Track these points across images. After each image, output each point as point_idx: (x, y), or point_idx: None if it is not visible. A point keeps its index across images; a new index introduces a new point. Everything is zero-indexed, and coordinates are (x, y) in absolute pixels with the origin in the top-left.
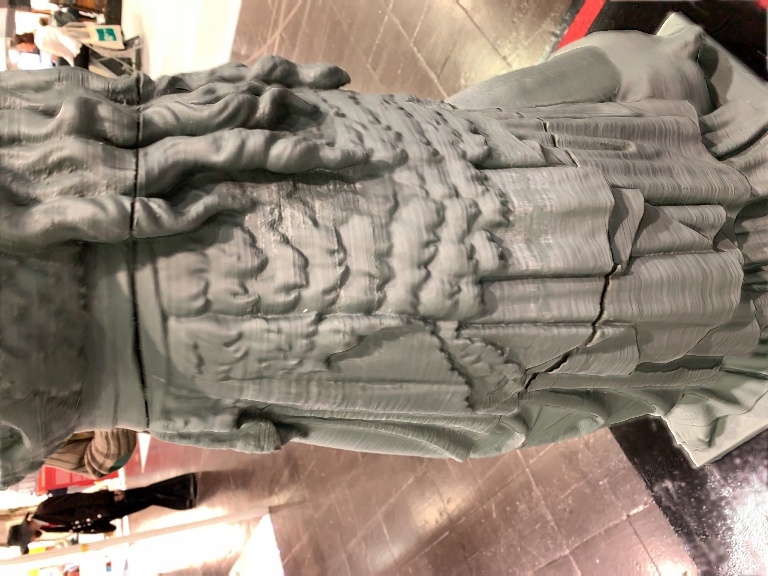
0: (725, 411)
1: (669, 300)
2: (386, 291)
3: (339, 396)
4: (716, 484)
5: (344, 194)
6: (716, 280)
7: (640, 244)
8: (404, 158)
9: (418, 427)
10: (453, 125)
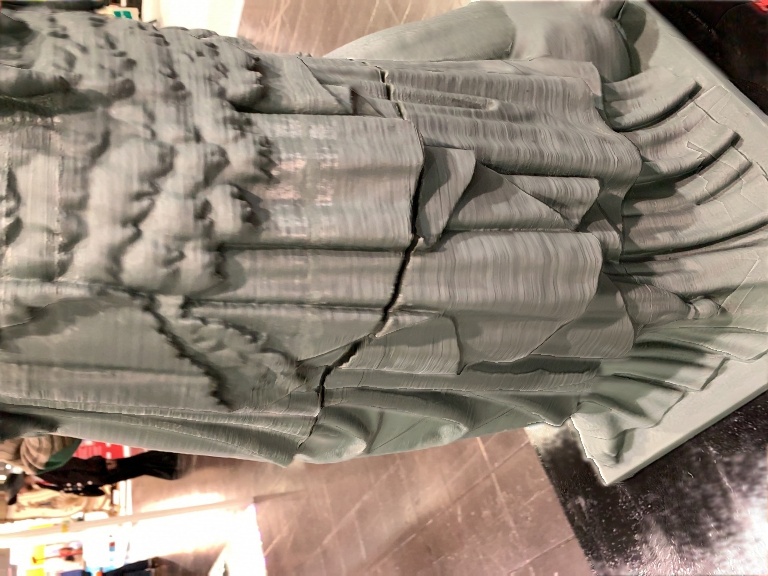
0: (631, 423)
1: (494, 285)
2: (74, 252)
3: (24, 382)
4: (627, 505)
5: (29, 128)
6: (563, 264)
7: (463, 216)
8: (127, 90)
9: (209, 425)
10: (224, 59)
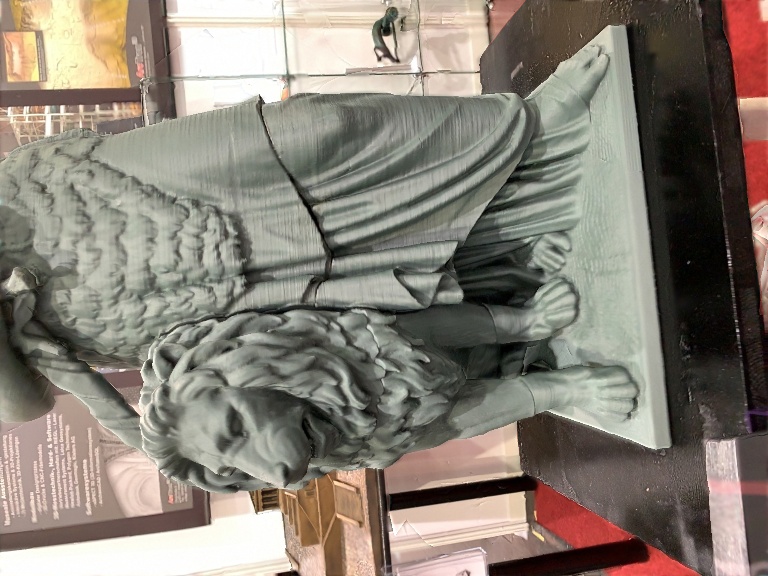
0: None
1: None
2: None
3: None
4: (625, 1)
5: None
6: None
7: None
8: None
9: None
10: None
